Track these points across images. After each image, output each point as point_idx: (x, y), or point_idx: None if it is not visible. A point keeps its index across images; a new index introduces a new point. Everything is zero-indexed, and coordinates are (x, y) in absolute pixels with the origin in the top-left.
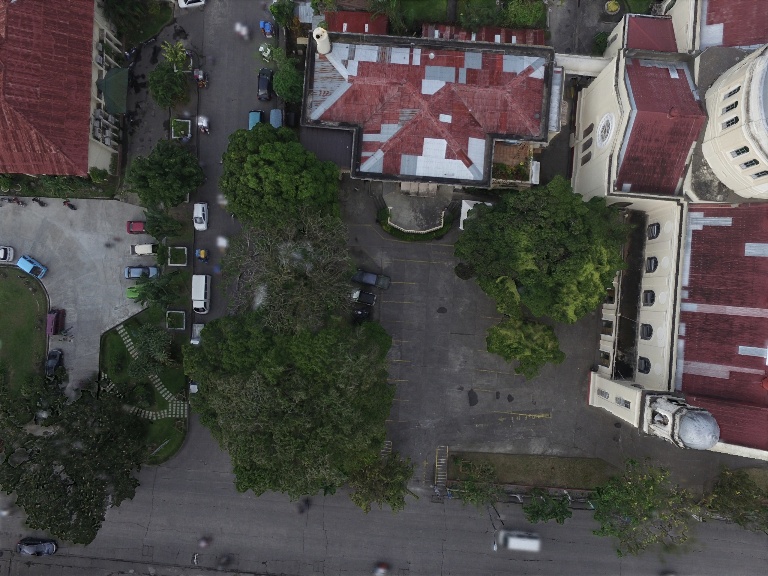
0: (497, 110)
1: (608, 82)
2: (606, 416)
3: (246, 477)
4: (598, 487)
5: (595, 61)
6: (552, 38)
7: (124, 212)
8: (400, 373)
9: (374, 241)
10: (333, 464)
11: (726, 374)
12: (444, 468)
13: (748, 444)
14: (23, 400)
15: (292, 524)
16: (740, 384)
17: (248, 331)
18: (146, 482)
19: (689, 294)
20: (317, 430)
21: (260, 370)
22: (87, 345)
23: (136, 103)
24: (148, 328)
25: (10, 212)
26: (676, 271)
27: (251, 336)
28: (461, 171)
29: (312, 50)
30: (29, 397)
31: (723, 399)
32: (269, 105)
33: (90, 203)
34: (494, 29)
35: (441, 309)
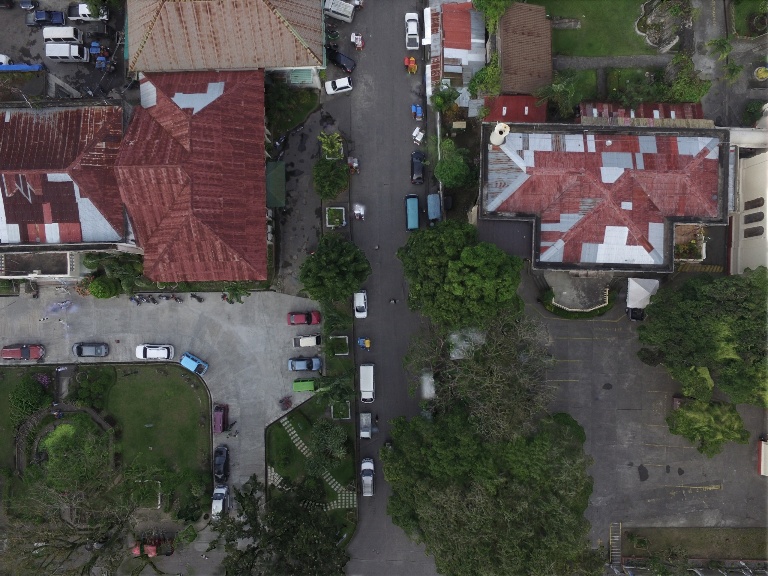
0: (676, 194)
1: None
2: None
3: None
4: None
5: (758, 133)
6: (702, 107)
7: (281, 303)
8: None
9: None
10: (556, 571)
11: None
12: (618, 545)
13: None
14: (193, 499)
15: None
16: None
17: (455, 437)
18: None
19: None
20: (543, 540)
21: (481, 482)
22: (251, 439)
23: (286, 192)
24: (323, 424)
25: (166, 309)
26: None
27: (460, 443)
28: (642, 256)
29: (485, 141)
30: (200, 496)
31: None
32: (421, 188)
33: None
34: (652, 104)
35: (606, 385)
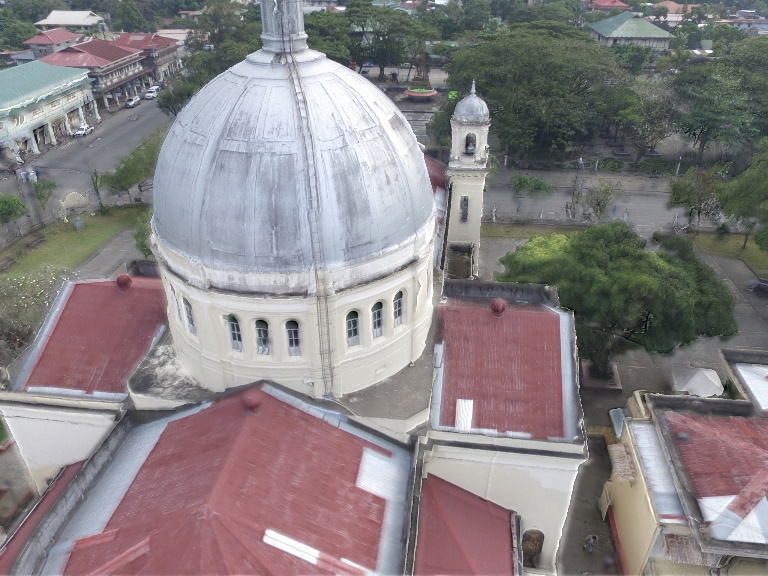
0: None
1: None
2: None
3: None
4: None
5: None
6: None
7: None
8: None
9: None
10: None
11: None
12: None
13: None
14: None
15: None
16: None
17: None
18: None
19: None
20: None
21: None
22: None
23: None
24: None
25: None
26: None
27: None
28: None
29: None
30: None
31: None
32: None
33: None
34: None
35: None
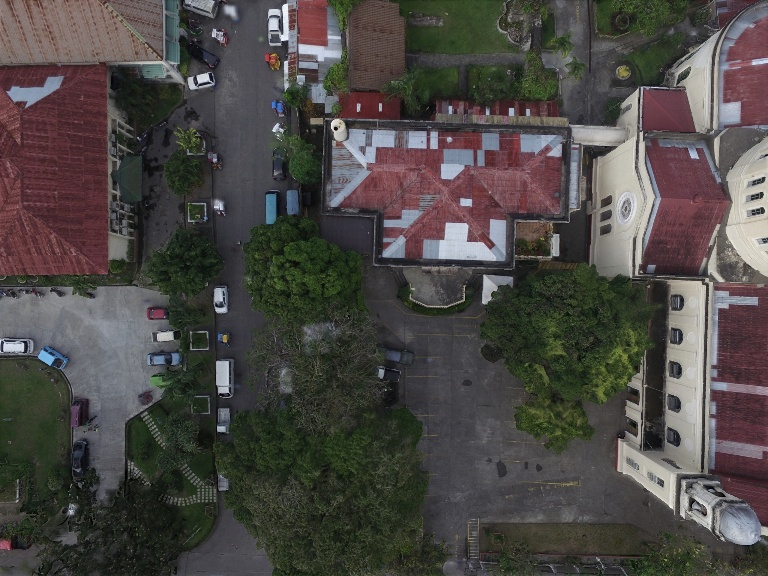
0: (517, 191)
1: (627, 160)
2: (635, 481)
3: None
4: None
5: (610, 132)
6: (565, 105)
7: (143, 298)
8: (428, 448)
9: (396, 316)
10: (373, 565)
11: (759, 454)
12: (476, 541)
13: None
14: (50, 493)
15: None
16: None
17: (280, 431)
18: (178, 569)
19: (718, 373)
20: (356, 533)
21: (296, 475)
22: (112, 434)
23: (150, 187)
24: (174, 419)
25: (28, 303)
26: (704, 351)
27: (284, 437)
28: (483, 253)
29: (329, 137)
30: (56, 490)
31: (757, 479)
32: (284, 184)
33: (108, 290)
34: (508, 102)
35: (466, 382)
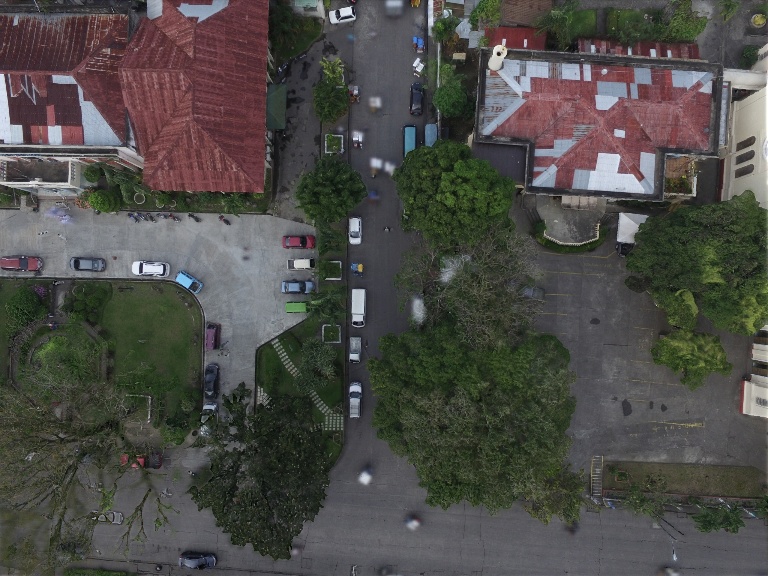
0: (668, 125)
1: None
2: (758, 424)
3: (448, 491)
4: (767, 496)
5: (752, 75)
6: (699, 51)
7: (277, 227)
8: None
9: None
10: (535, 478)
11: None
12: (599, 478)
13: None
14: (182, 415)
15: (449, 535)
16: None
17: (441, 347)
18: None
19: None
20: (523, 445)
21: (465, 386)
22: (242, 359)
23: (287, 118)
24: (313, 342)
25: (164, 228)
26: None
27: (446, 352)
28: (632, 185)
29: (483, 67)
30: (189, 412)
31: None
32: (420, 119)
33: (243, 218)
34: (649, 43)
35: (594, 320)
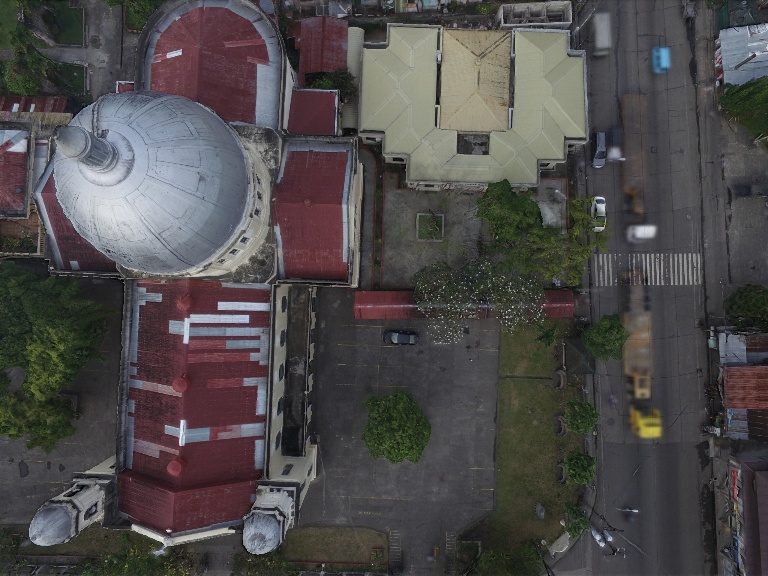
0: None
1: None
2: None
3: None
4: None
5: None
6: None
7: None
8: None
9: None
10: None
11: (157, 453)
12: None
13: (157, 527)
14: None
15: None
16: (165, 464)
17: None
18: None
19: (137, 371)
20: None
21: None
22: None
23: None
24: None
25: None
26: None
27: None
28: None
29: None
30: None
31: (153, 479)
32: None
33: None
34: (14, 98)
35: None
